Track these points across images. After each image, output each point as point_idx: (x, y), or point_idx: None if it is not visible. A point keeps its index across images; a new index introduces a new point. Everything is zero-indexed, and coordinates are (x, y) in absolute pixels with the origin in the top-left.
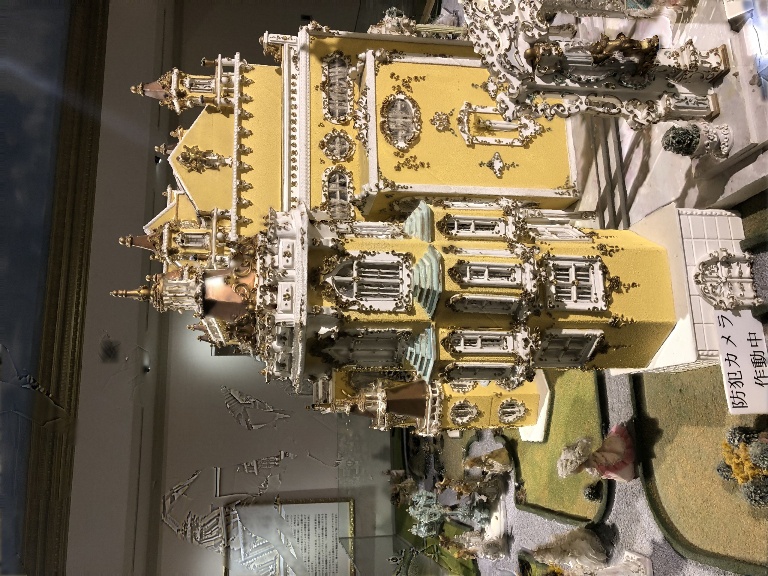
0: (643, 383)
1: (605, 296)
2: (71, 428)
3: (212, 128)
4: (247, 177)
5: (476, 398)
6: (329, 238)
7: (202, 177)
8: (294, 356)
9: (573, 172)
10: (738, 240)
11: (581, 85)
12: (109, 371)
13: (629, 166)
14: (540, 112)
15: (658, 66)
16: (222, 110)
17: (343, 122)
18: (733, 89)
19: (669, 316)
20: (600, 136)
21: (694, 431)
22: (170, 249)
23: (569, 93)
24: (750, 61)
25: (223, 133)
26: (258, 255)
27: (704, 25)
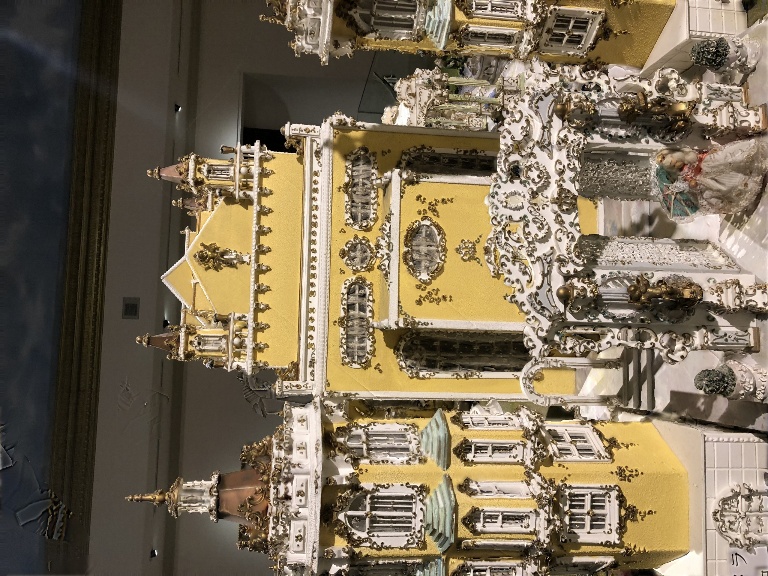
0: None
1: (619, 528)
2: (91, 570)
3: (230, 221)
4: (265, 278)
5: None
6: (343, 470)
7: (219, 276)
8: None
9: None
10: (763, 469)
11: (615, 321)
12: (128, 417)
13: None
14: (569, 350)
15: (699, 303)
16: (241, 202)
17: (365, 228)
18: None
19: (683, 544)
20: None
21: None
22: (187, 353)
23: (601, 326)
24: None
25: (241, 227)
26: (272, 482)
27: (755, 244)
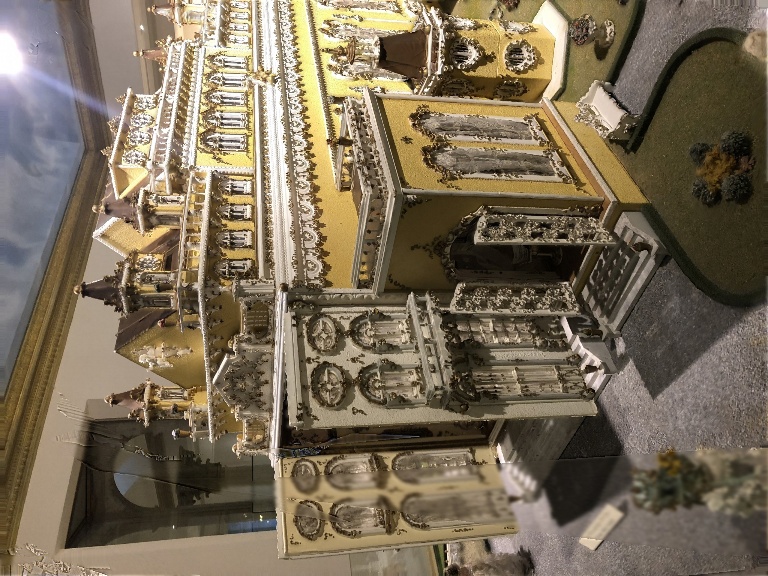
0: None
1: None
2: None
3: None
4: None
5: None
6: None
7: None
8: None
9: None
10: None
11: None
12: None
13: None
14: None
15: None
16: None
17: None
18: None
19: None
20: None
21: None
22: None
23: None
24: None
25: None
26: None
27: None
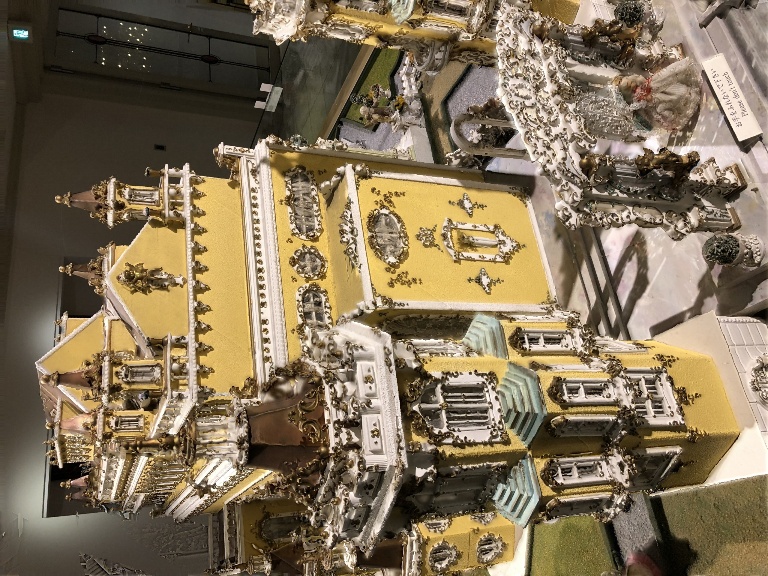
0: (660, 501)
1: (679, 409)
2: None
3: (157, 244)
4: (204, 298)
5: (454, 537)
6: None
7: (148, 299)
8: (374, 509)
9: (552, 287)
10: None
11: (629, 196)
12: None
13: (621, 279)
14: (599, 221)
15: (688, 181)
16: (168, 224)
17: (312, 238)
18: (754, 203)
19: (732, 426)
20: (582, 252)
21: (741, 548)
22: (111, 387)
23: (618, 203)
24: (767, 178)
25: (170, 250)
26: (325, 383)
27: (706, 147)
